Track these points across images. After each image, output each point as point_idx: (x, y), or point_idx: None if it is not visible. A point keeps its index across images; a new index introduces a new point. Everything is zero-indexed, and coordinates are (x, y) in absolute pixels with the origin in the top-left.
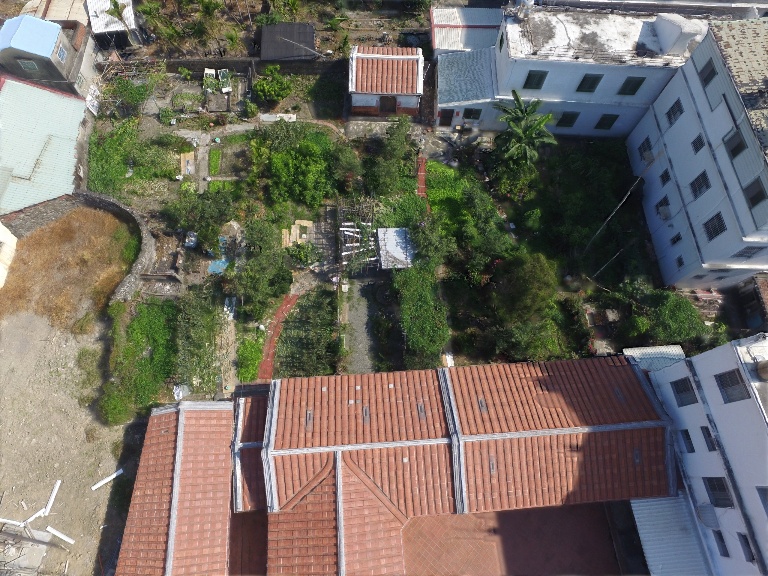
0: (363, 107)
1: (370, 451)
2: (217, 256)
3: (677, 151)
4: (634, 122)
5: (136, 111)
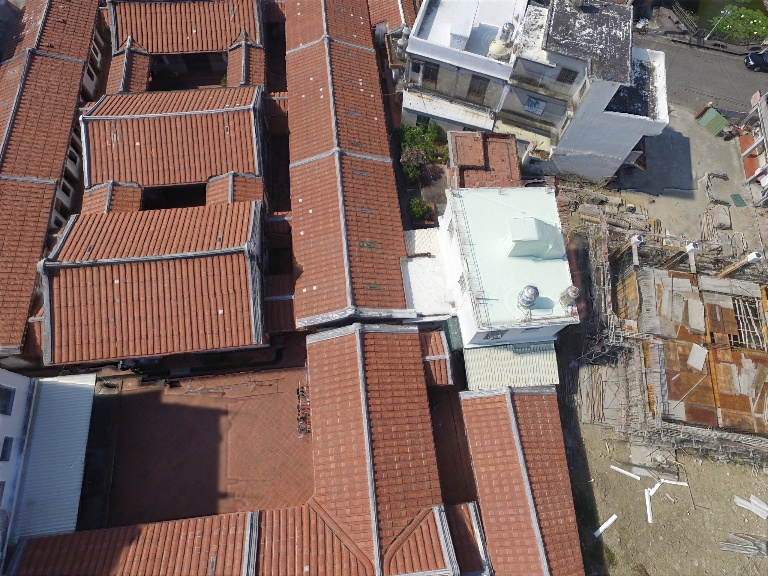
0: None
1: None
2: None
3: None
4: None
5: None
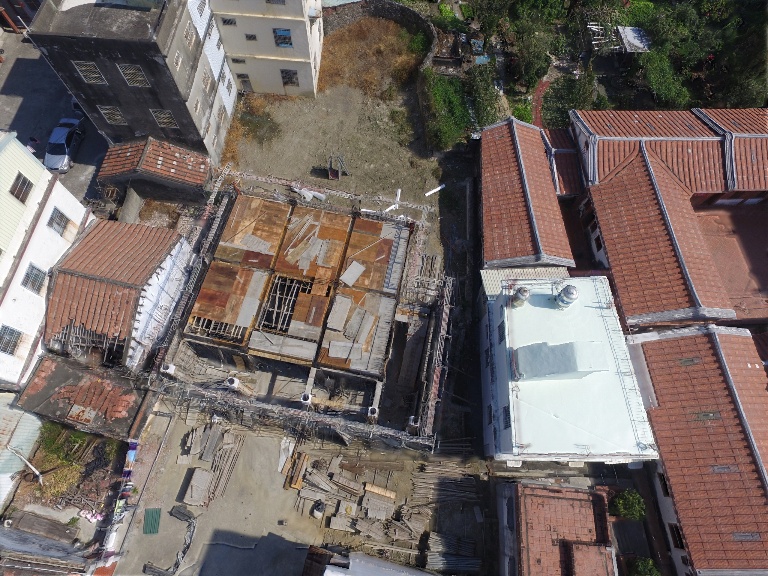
0: None
1: (664, 143)
2: (484, 50)
3: None
4: None
5: None
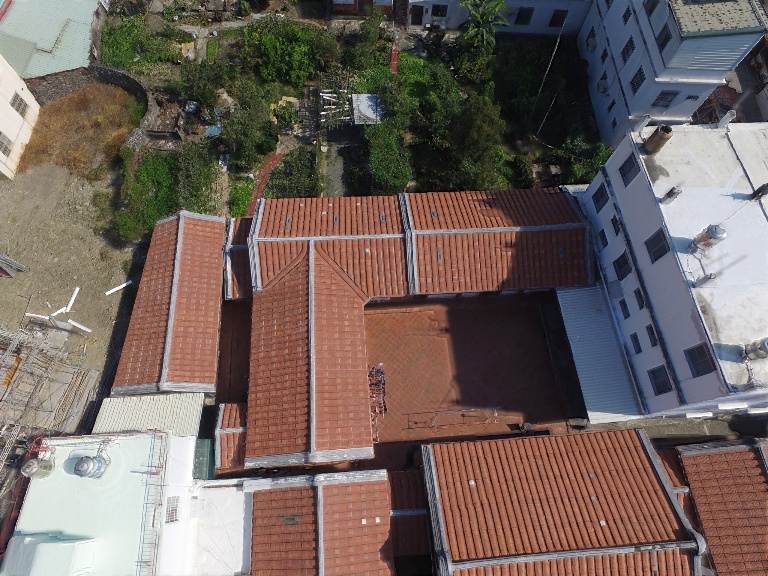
0: (343, 5)
1: (338, 242)
2: (213, 120)
3: (613, 30)
4: (583, 18)
5: (143, 7)
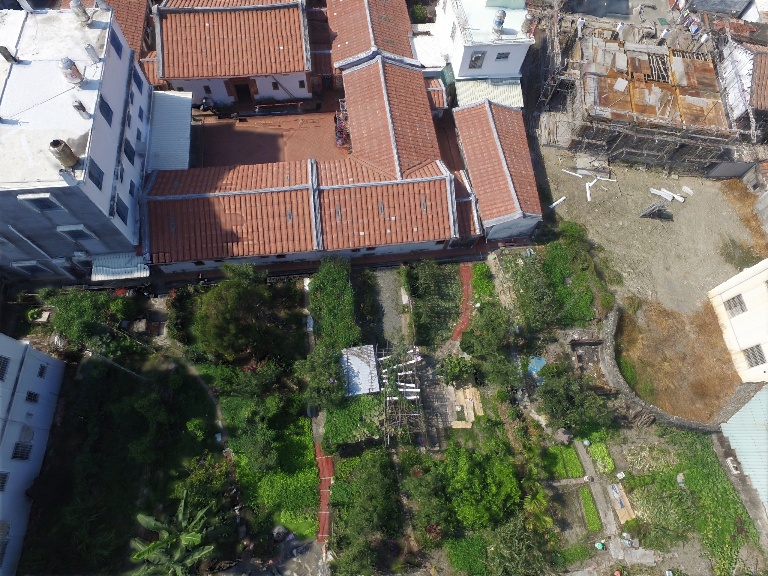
0: None
1: None
2: None
3: None
4: None
5: None
